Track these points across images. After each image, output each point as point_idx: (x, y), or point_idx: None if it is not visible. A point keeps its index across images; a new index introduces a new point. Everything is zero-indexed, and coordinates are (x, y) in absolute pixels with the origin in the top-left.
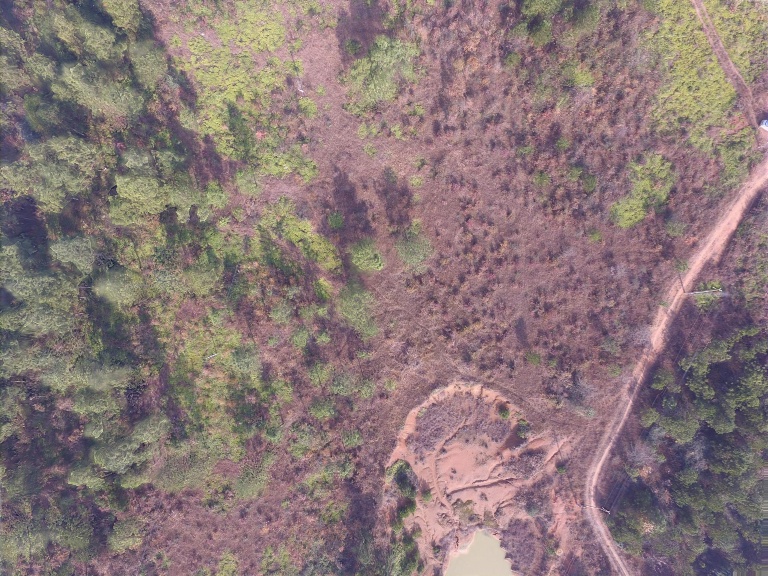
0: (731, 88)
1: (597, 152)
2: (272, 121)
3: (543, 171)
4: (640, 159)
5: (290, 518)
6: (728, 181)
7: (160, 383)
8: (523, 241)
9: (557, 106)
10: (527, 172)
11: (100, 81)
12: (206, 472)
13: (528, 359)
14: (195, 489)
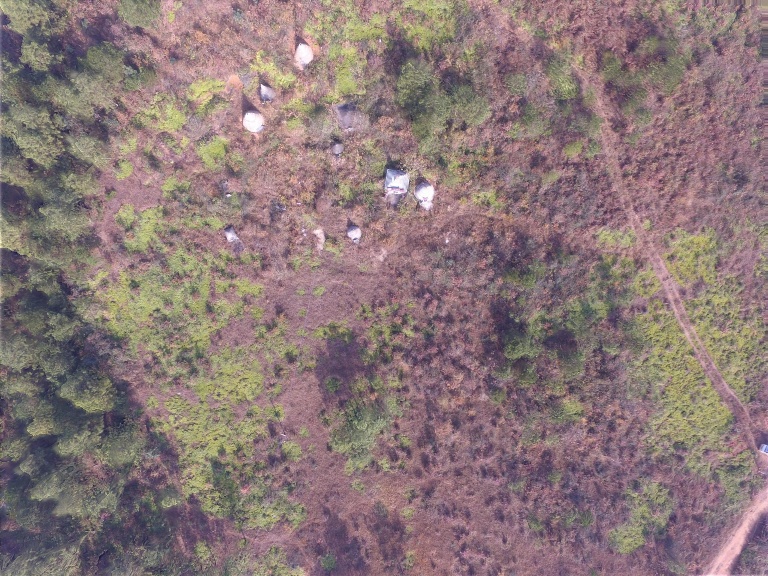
0: (727, 411)
1: (591, 481)
2: (256, 471)
3: (537, 499)
4: (636, 488)
5: None
6: (729, 507)
7: None
8: (521, 567)
9: (547, 441)
10: (520, 498)
11: None
12: None
13: None
14: None
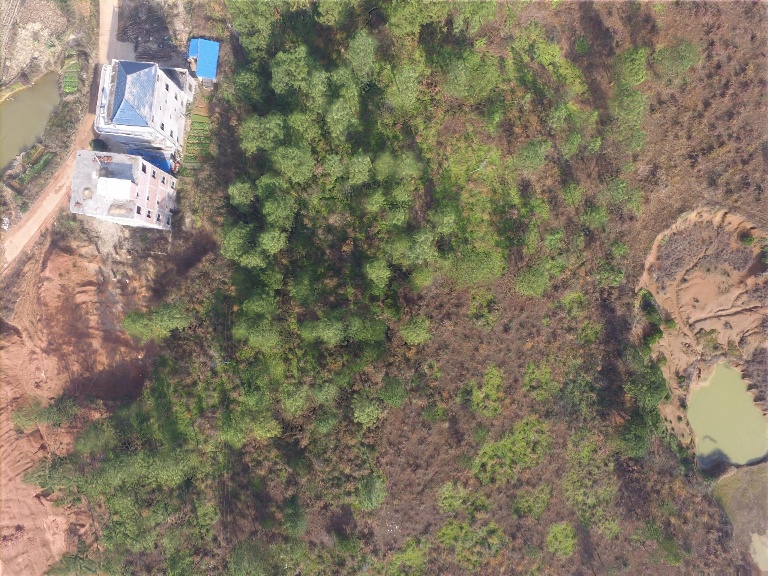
0: None
1: None
2: None
3: None
4: None
5: (550, 335)
6: None
7: (425, 197)
8: None
9: None
10: None
11: None
12: (472, 285)
13: None
14: (462, 301)
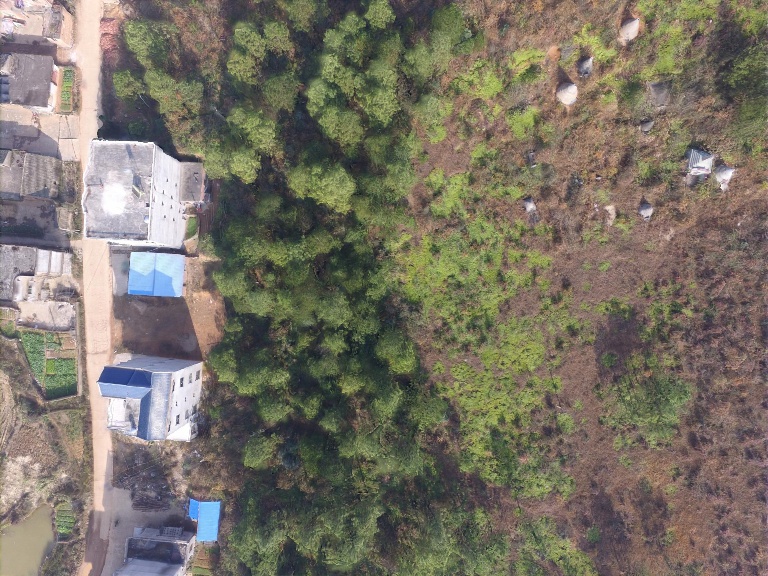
0: None
1: None
2: (532, 441)
3: None
4: None
5: None
6: None
7: None
8: None
9: None
10: None
11: (358, 404)
12: None
13: None
14: None
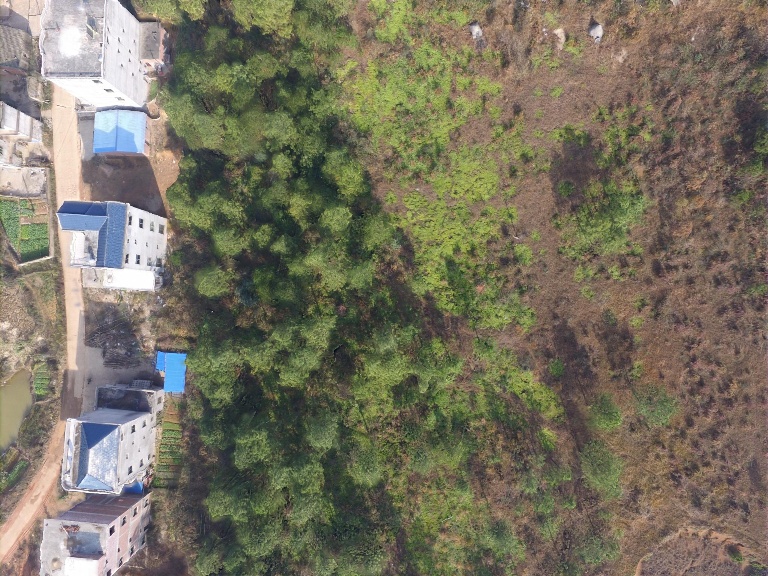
0: None
1: None
2: (489, 271)
3: None
4: None
5: None
6: None
7: (398, 549)
8: (753, 380)
9: None
10: (755, 308)
11: (313, 240)
12: None
13: (764, 502)
14: None
